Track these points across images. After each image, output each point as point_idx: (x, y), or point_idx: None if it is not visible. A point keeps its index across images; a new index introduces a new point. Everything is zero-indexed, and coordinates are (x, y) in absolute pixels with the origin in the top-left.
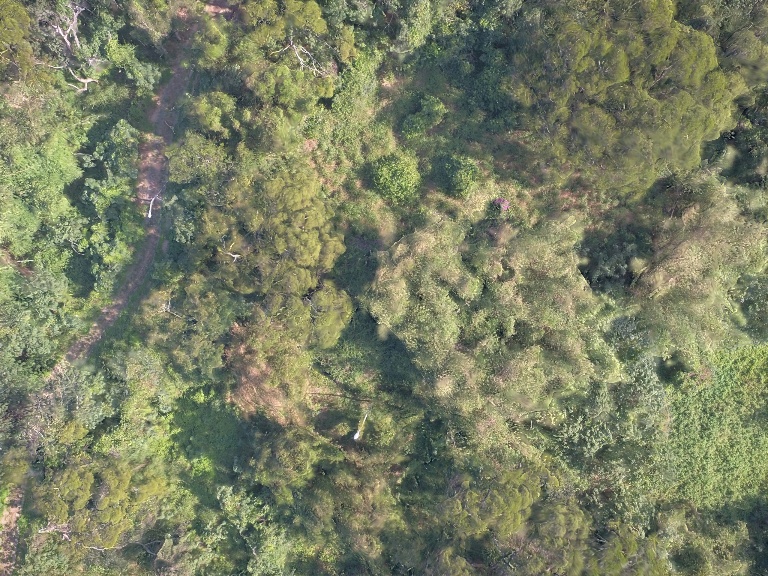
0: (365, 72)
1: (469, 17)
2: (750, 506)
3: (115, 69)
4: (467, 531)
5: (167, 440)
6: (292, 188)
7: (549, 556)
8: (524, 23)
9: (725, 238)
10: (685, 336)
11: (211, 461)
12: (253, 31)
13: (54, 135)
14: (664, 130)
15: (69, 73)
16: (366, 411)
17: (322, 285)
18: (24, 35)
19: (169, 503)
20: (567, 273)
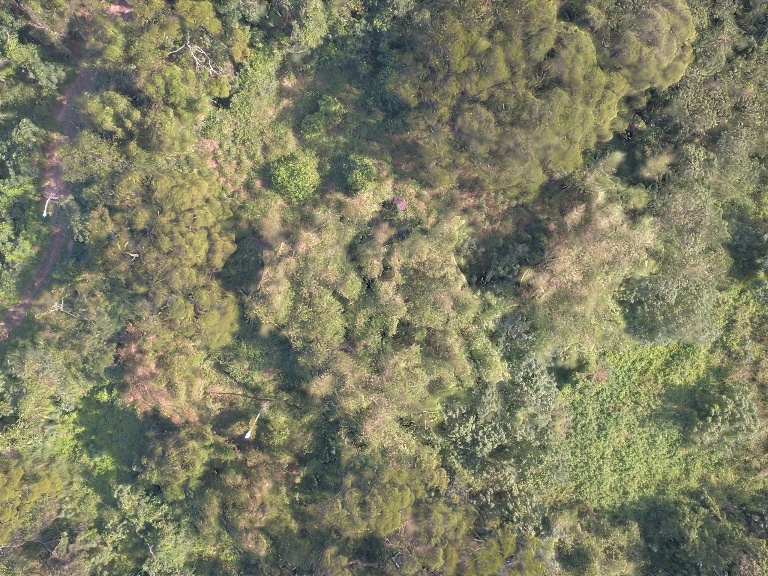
0: (264, 72)
1: (364, 17)
2: (647, 506)
3: (19, 69)
4: (346, 530)
5: (71, 439)
6: (181, 188)
7: (425, 555)
8: (414, 24)
9: (605, 238)
10: (568, 336)
11: (114, 460)
12: None
13: None
14: (541, 131)
15: None
16: (267, 410)
17: (209, 284)
18: None
19: (71, 502)
20: (445, 273)
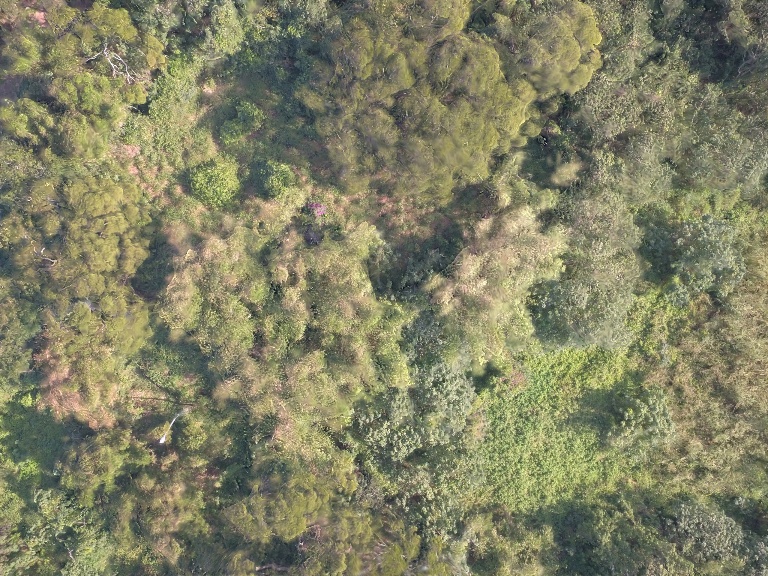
0: (184, 78)
1: (279, 24)
2: (564, 510)
3: None
4: (251, 535)
5: None
6: (93, 194)
7: (328, 560)
8: (325, 30)
9: (509, 244)
10: (474, 341)
11: (38, 464)
12: (75, 38)
13: None
14: (443, 137)
15: None
16: (189, 415)
17: (119, 290)
18: None
19: None
20: (348, 279)
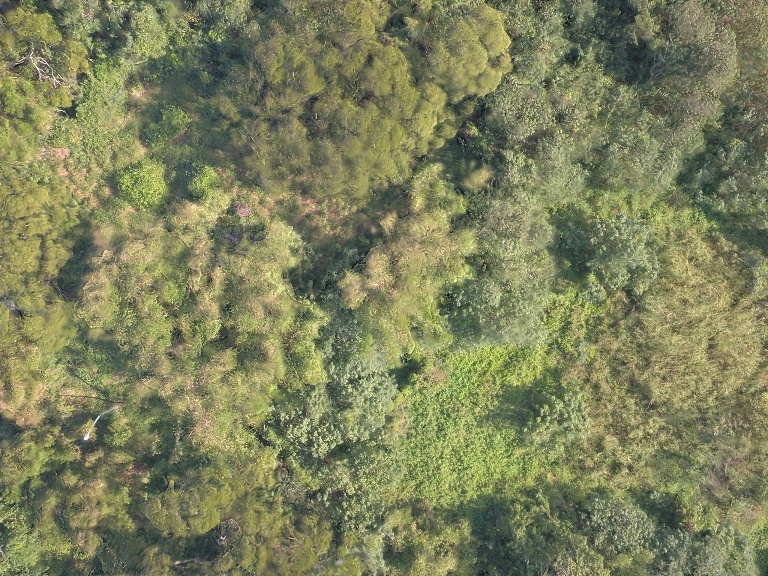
0: (111, 82)
1: (201, 29)
2: (485, 505)
3: None
4: (165, 529)
5: None
6: (15, 196)
7: (239, 553)
8: (243, 35)
9: (417, 244)
10: (385, 339)
11: None
12: None
13: None
14: (350, 139)
15: None
16: (119, 413)
17: (40, 290)
18: None
19: None
20: (259, 278)
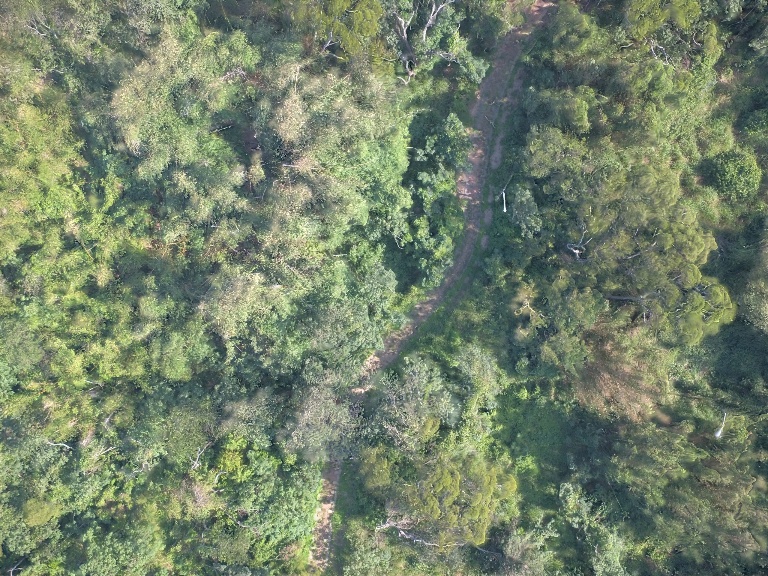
0: None
1: None
2: None
3: (441, 62)
4: None
5: (487, 437)
6: (668, 183)
7: None
8: None
9: None
10: None
11: (534, 458)
12: None
13: (399, 128)
14: None
15: (401, 66)
16: (696, 409)
17: (704, 281)
18: (375, 27)
19: None
20: None
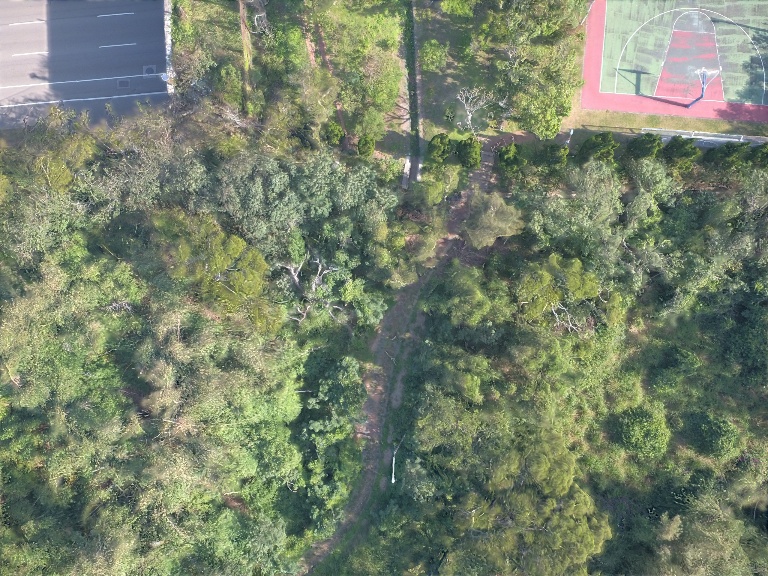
0: None
1: (739, 277)
2: None
3: None
4: None
5: None
6: (561, 471)
7: None
8: None
9: None
10: None
11: None
12: (494, 270)
13: (285, 384)
14: None
15: (293, 308)
16: None
17: None
18: (260, 281)
19: None
20: None
